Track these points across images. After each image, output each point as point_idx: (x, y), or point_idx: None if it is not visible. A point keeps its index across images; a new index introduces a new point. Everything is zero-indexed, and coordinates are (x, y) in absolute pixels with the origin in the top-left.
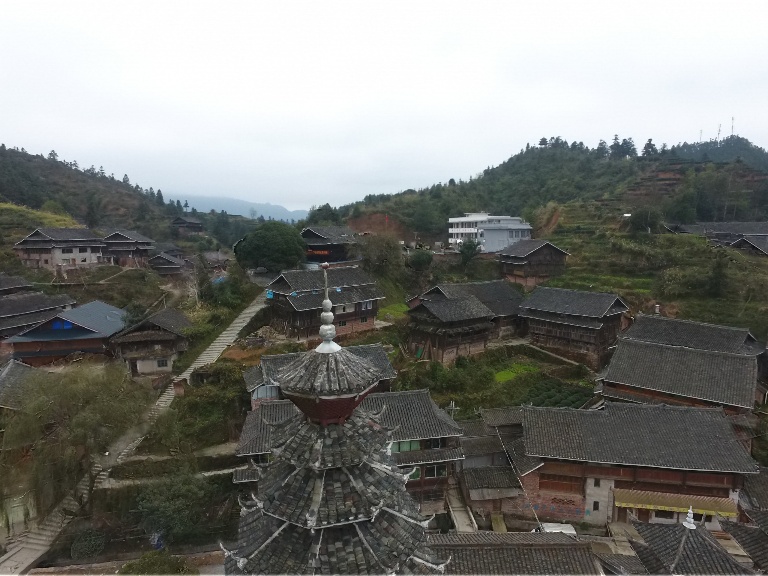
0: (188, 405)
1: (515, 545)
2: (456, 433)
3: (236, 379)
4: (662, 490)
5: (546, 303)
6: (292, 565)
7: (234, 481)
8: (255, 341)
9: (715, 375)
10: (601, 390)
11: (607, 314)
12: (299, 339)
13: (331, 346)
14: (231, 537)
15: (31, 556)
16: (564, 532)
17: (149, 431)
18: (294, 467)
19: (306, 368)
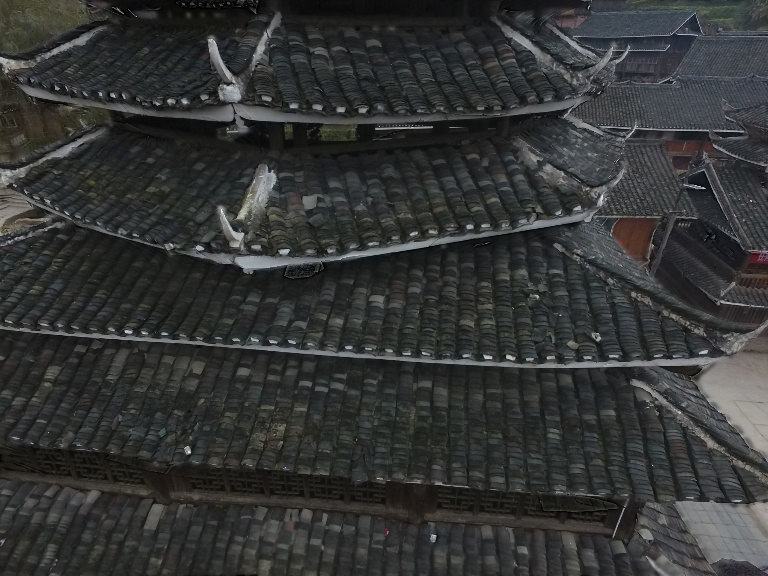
0: None
1: None
2: None
3: None
4: None
5: (601, 29)
6: None
7: None
8: None
9: None
10: None
11: (678, 32)
12: None
13: None
14: None
15: (18, 210)
16: None
17: None
18: None
19: None
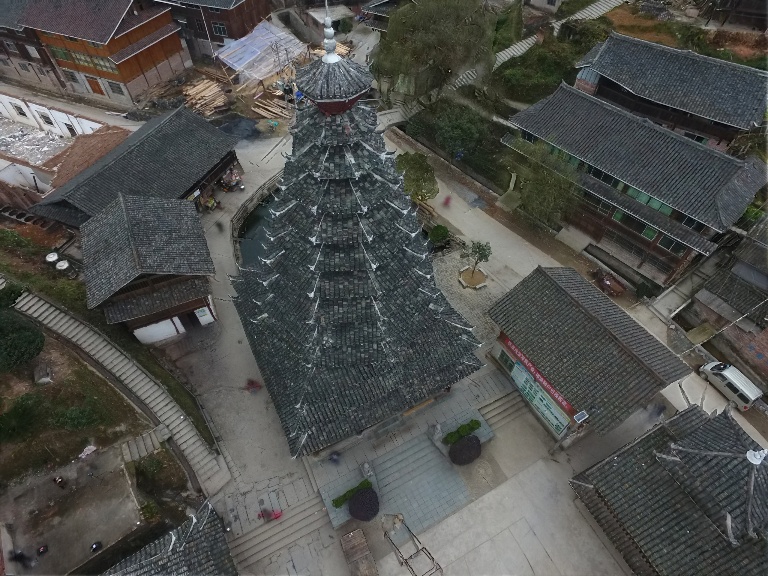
0: (538, 56)
1: (604, 327)
2: (715, 226)
3: None
4: None
5: None
6: None
7: (501, 140)
8: (652, 7)
9: None
10: None
11: None
12: (708, 24)
13: (328, 57)
14: (495, 181)
15: (398, 118)
16: (741, 388)
17: None
18: None
19: None
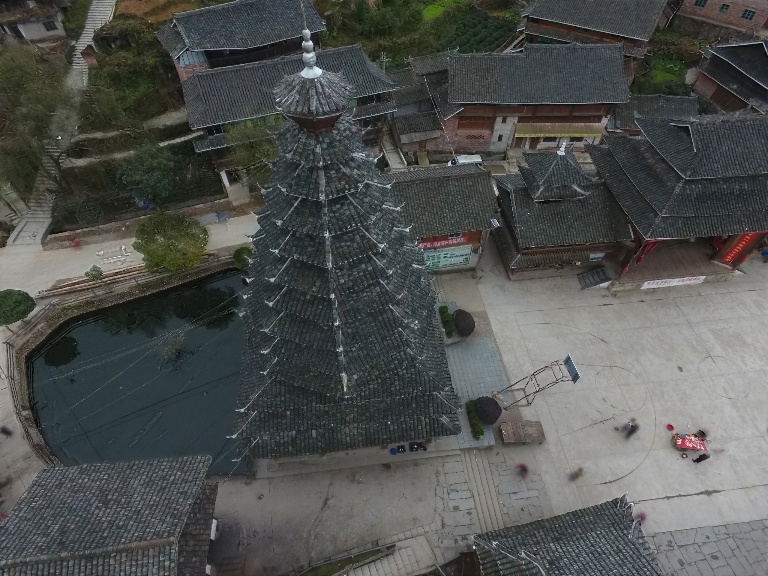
0: (109, 77)
1: (437, 178)
2: (390, 88)
3: (149, 41)
4: (553, 121)
5: None
6: (312, 220)
7: (197, 151)
8: None
9: (630, 6)
10: (524, 27)
11: None
12: None
13: (314, 71)
14: (206, 193)
15: (40, 227)
16: (473, 161)
17: (90, 112)
18: (299, 163)
19: (299, 93)
